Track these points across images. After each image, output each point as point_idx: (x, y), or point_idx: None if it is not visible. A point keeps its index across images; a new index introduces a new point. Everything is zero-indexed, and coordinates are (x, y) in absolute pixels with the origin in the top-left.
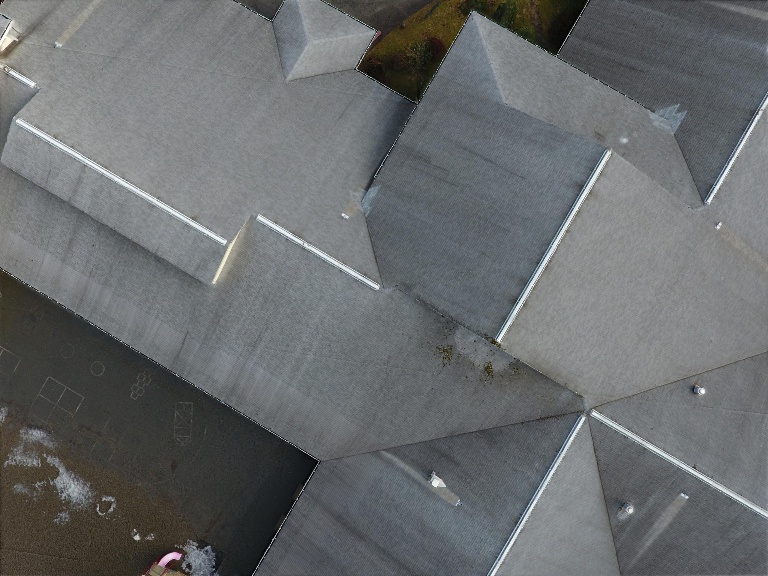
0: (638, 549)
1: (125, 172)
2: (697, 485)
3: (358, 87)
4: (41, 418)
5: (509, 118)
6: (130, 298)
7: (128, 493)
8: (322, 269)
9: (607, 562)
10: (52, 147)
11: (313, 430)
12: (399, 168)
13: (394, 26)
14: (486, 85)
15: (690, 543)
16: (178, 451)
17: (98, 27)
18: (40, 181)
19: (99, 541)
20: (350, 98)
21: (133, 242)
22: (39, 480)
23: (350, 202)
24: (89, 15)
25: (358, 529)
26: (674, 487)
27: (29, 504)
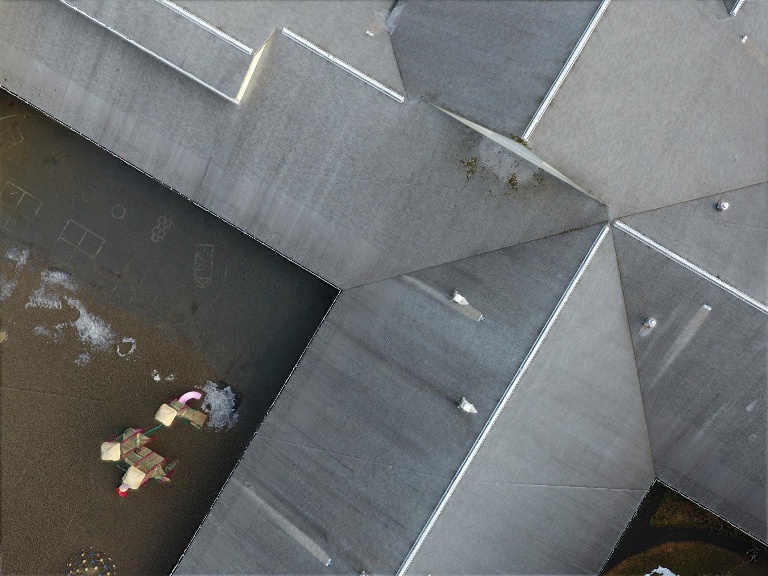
0: (660, 367)
1: None
2: (720, 295)
3: None
4: (62, 261)
5: None
6: (153, 125)
7: (148, 335)
8: (347, 83)
9: (628, 381)
10: None
11: (335, 257)
12: None
13: None
14: None
15: (712, 358)
16: (198, 293)
17: None
18: None
19: (119, 382)
20: None
21: (157, 64)
22: (60, 322)
23: (375, 21)
24: None
25: (380, 351)
26: (697, 298)
27: (50, 346)
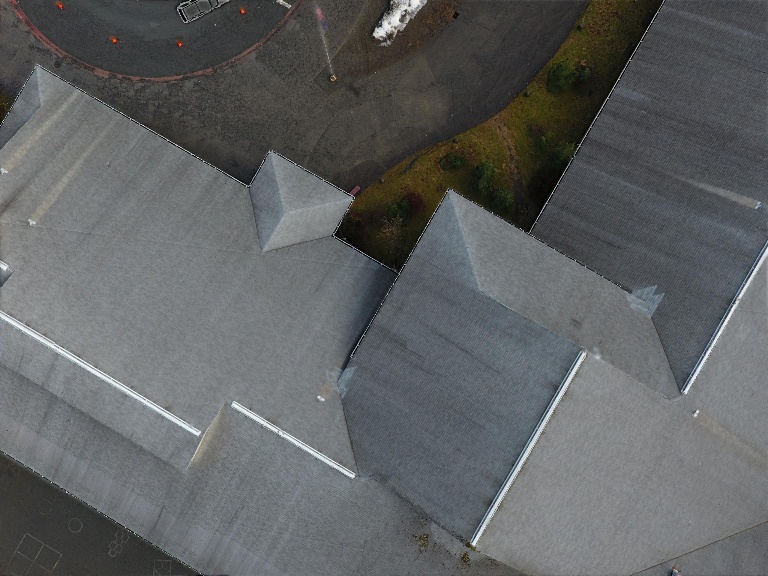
0: None
1: (98, 360)
2: None
3: (335, 256)
4: (18, 575)
5: (485, 307)
6: (106, 471)
7: None
8: (297, 456)
9: None
10: (24, 335)
11: None
12: (375, 350)
13: (373, 180)
14: (462, 270)
15: None
16: None
17: (72, 201)
18: (13, 365)
19: None
20: (327, 268)
21: None
22: None
23: (326, 383)
24: (63, 188)
25: None
26: None
27: None
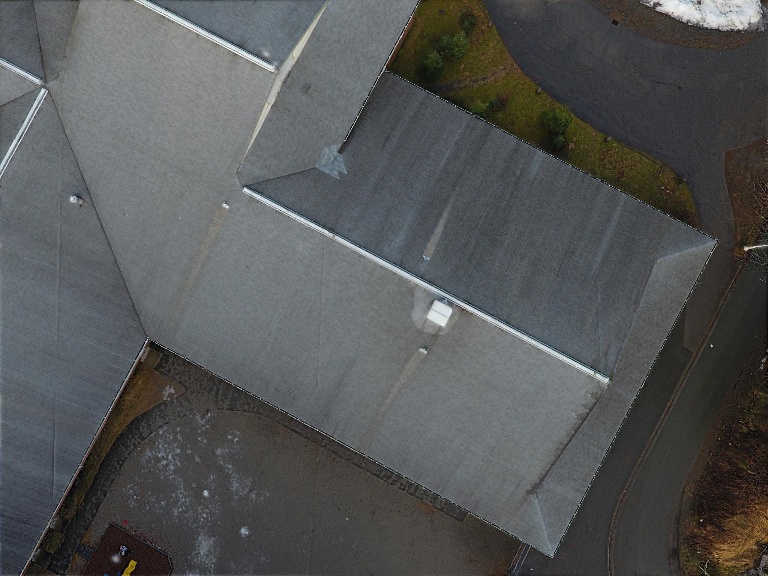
0: None
1: None
2: None
3: None
4: None
5: None
6: None
7: None
8: None
9: None
10: None
11: None
12: None
13: None
14: None
15: None
16: None
17: None
18: None
19: None
20: None
21: None
22: None
23: None
24: None
25: None
26: None
27: None
